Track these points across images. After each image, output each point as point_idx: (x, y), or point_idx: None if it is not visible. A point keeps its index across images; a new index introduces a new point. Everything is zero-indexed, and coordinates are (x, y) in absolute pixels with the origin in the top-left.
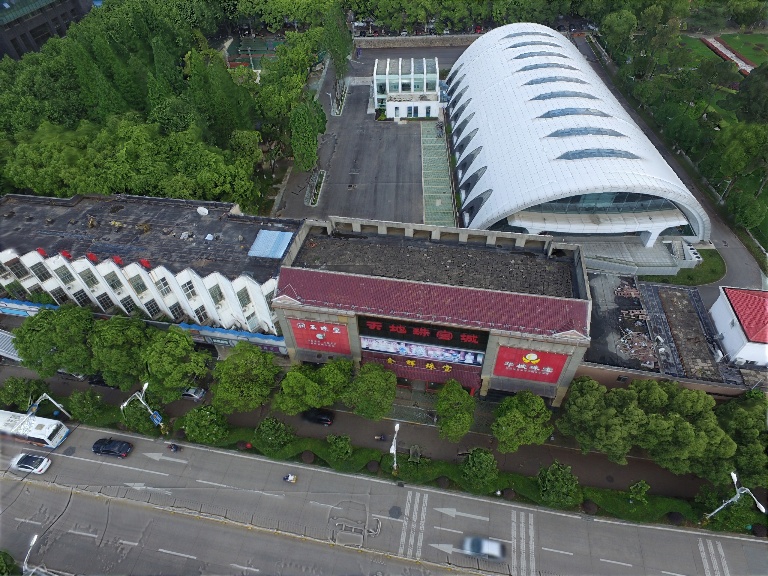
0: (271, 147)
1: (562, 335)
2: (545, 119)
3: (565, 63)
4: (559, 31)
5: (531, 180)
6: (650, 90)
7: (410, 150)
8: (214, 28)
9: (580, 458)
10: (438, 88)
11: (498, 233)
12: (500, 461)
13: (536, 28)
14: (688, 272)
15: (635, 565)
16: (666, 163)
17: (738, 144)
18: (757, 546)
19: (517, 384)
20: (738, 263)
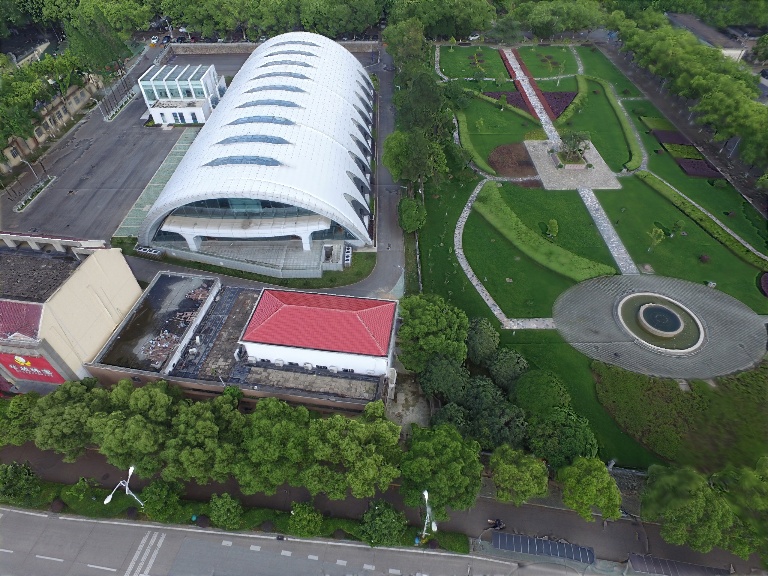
0: (4, 152)
1: (17, 338)
2: (229, 126)
3: (300, 72)
4: (371, 40)
5: (174, 186)
6: (402, 99)
7: (156, 156)
8: (5, 31)
9: (91, 457)
10: (210, 95)
11: (33, 238)
12: (6, 463)
13: (306, 37)
14: (335, 274)
15: (66, 560)
16: (334, 170)
17: (388, 152)
18: (198, 536)
19: (41, 386)
20: (387, 265)
